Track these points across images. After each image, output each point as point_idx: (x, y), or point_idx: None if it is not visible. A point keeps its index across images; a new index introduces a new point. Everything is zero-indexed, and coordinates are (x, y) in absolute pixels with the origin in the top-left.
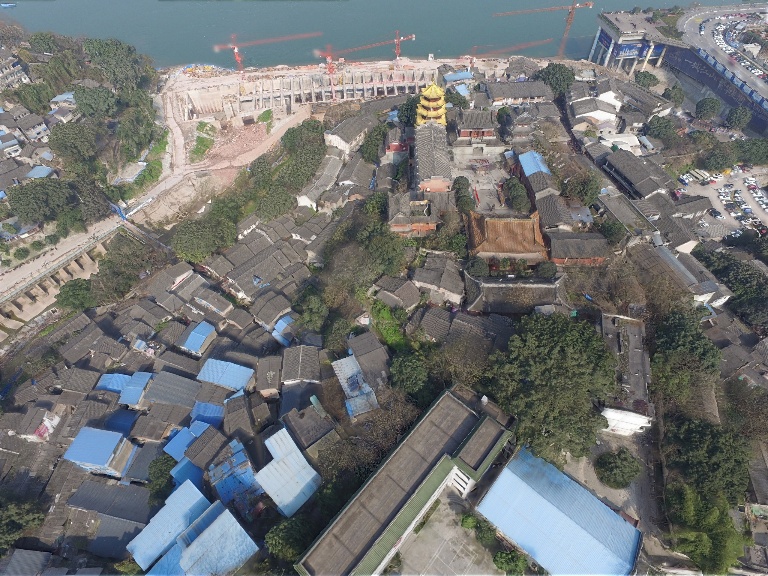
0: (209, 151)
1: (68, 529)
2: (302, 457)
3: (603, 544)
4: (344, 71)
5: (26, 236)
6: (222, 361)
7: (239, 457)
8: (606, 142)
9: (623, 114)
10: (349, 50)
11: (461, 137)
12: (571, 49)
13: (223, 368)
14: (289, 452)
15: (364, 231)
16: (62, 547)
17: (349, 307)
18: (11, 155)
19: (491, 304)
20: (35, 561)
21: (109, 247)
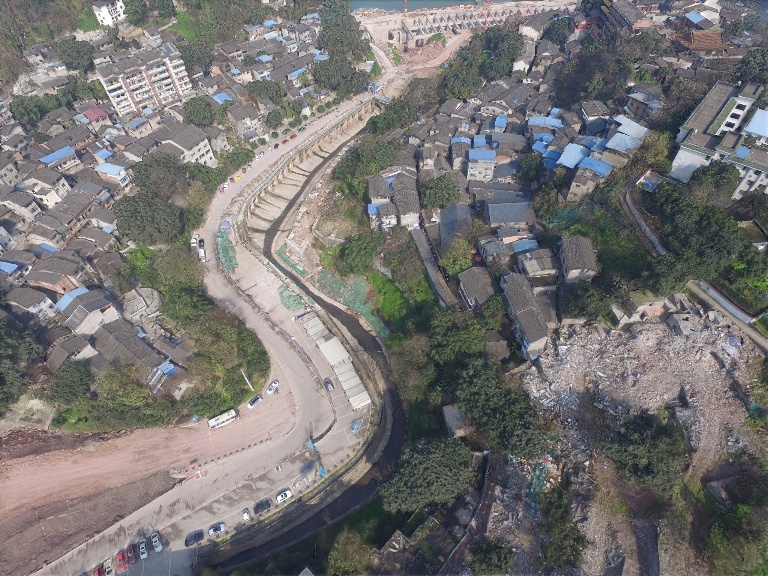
0: (403, 60)
1: (476, 198)
2: (637, 124)
3: None
4: (481, 9)
5: (323, 97)
6: (540, 117)
7: (590, 137)
8: None
9: (724, 14)
10: None
11: None
12: None
13: (543, 119)
14: (629, 122)
15: (617, 41)
16: (476, 205)
17: (610, 86)
18: (291, 51)
19: (710, 68)
20: (466, 209)
21: (410, 86)
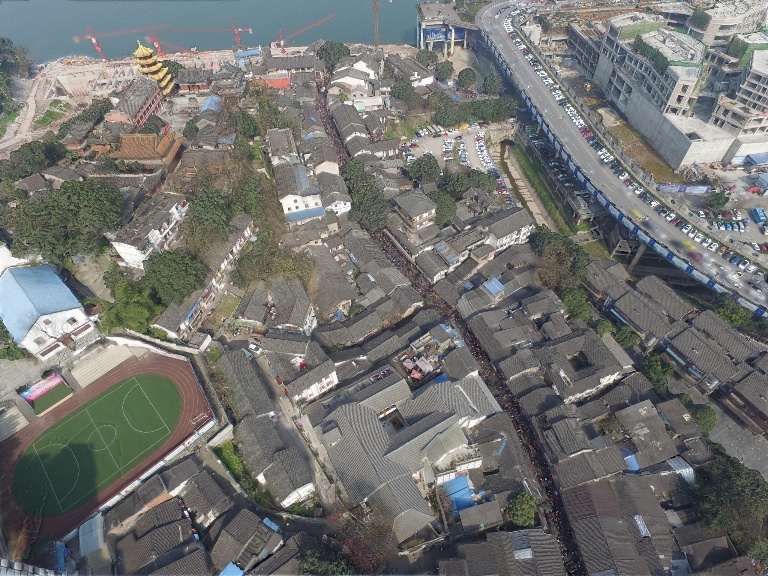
0: (55, 122)
1: None
2: None
3: (34, 305)
4: (195, 58)
5: None
6: None
7: None
8: (348, 102)
9: (373, 80)
10: (215, 43)
11: (181, 90)
12: (410, 38)
13: None
14: None
15: None
16: None
17: None
18: None
19: None
20: None
21: None
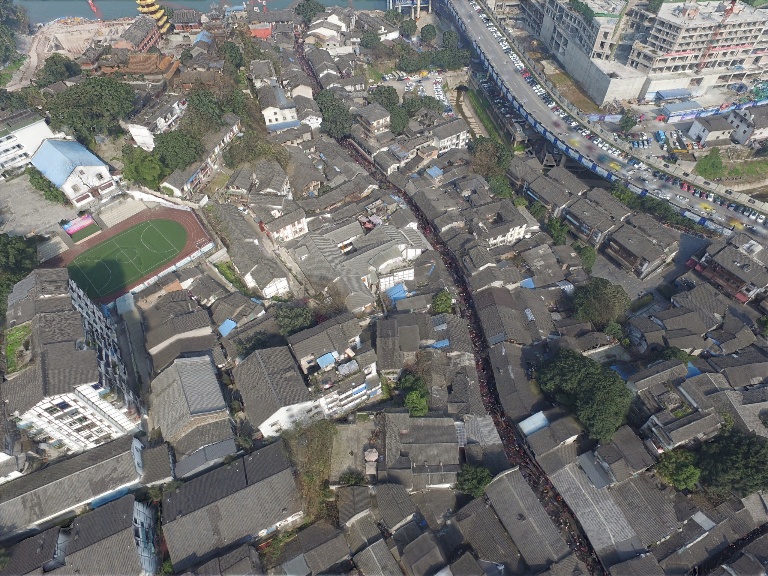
0: None
1: None
2: None
3: None
4: None
5: None
6: None
7: None
8: None
9: (345, 32)
10: None
11: (176, 30)
12: (382, 6)
13: None
14: None
15: None
16: None
17: None
18: None
19: None
20: None
21: None
